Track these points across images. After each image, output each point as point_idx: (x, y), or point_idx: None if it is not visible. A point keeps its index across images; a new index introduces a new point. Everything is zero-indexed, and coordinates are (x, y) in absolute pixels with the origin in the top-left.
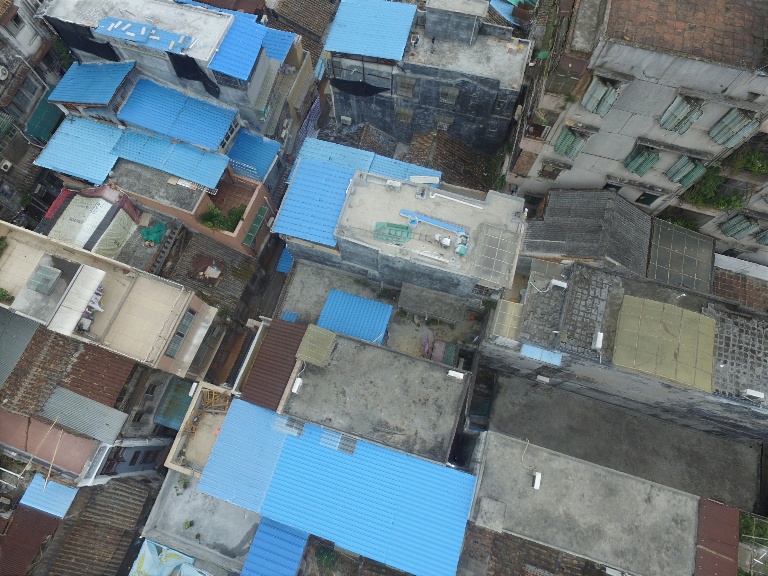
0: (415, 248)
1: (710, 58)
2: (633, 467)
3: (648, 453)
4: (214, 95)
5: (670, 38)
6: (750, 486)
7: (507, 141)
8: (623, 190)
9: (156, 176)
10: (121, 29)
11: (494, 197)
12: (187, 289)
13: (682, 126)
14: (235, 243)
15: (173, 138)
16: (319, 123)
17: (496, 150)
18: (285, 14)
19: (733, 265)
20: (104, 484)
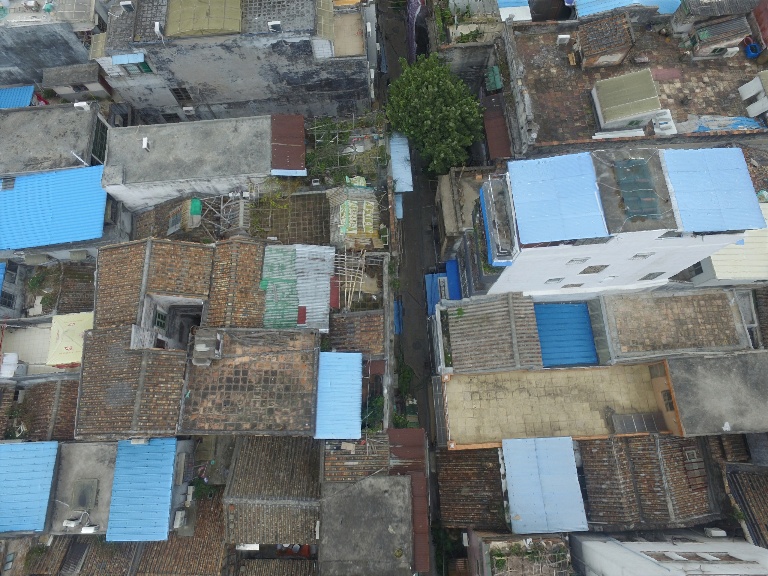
0: (12, 19)
1: None
2: None
3: None
4: None
5: None
6: None
7: None
8: None
9: None
10: None
11: None
12: None
13: None
14: None
15: None
16: None
17: None
18: None
19: None
20: None
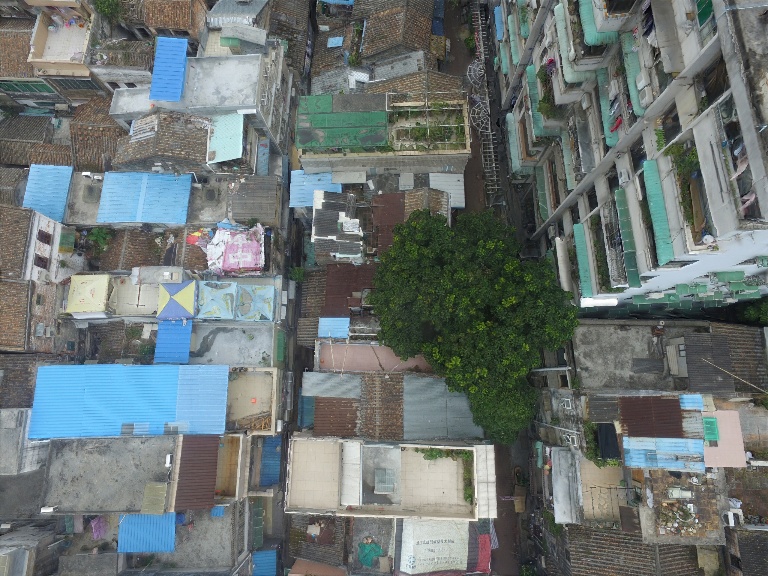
0: None
1: None
2: None
3: None
4: None
5: None
6: None
7: None
8: None
9: None
10: None
11: None
12: None
13: None
14: (298, 567)
15: None
16: None
17: None
18: None
19: None
20: None
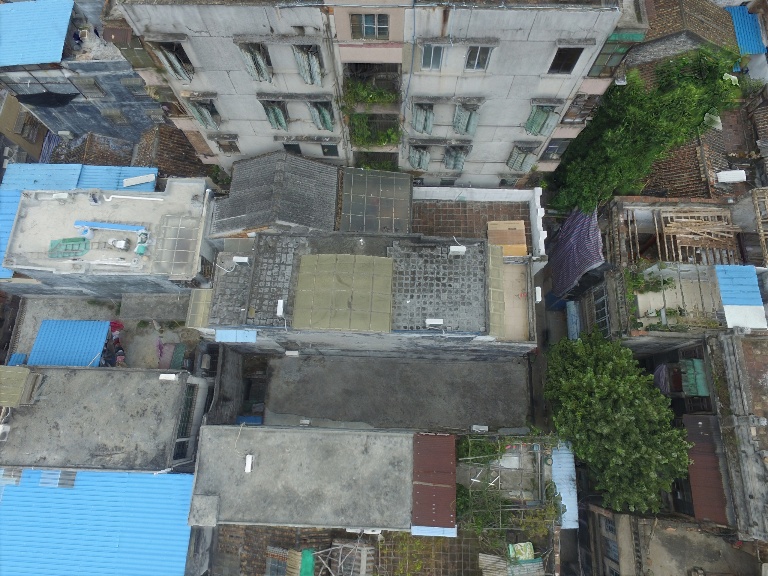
0: (94, 259)
1: None
2: (410, 413)
3: (423, 396)
4: None
5: None
6: (521, 401)
7: None
8: (302, 147)
9: None
10: None
11: (175, 185)
12: None
13: (265, 74)
14: None
15: None
16: None
17: None
18: None
19: (448, 194)
20: None
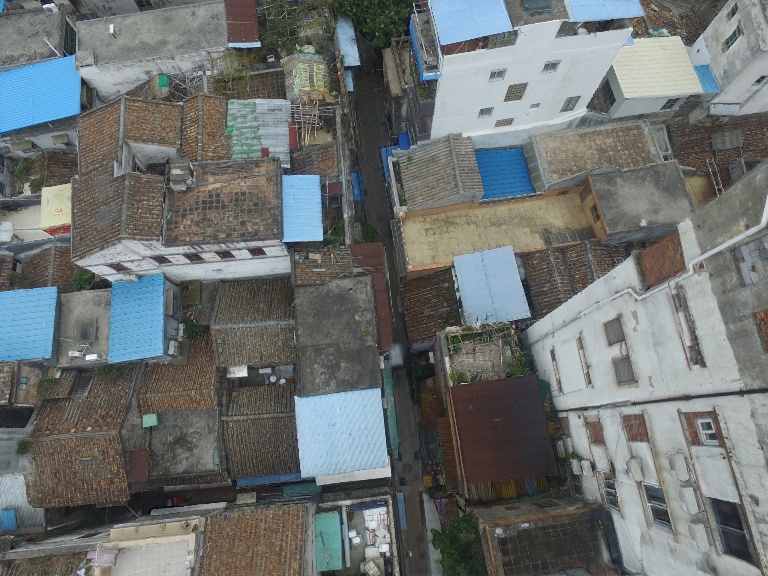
0: None
1: None
2: None
3: None
4: None
5: None
6: None
7: None
8: None
9: None
10: None
11: None
12: None
13: None
14: None
15: None
16: None
17: None
18: None
19: None
20: None
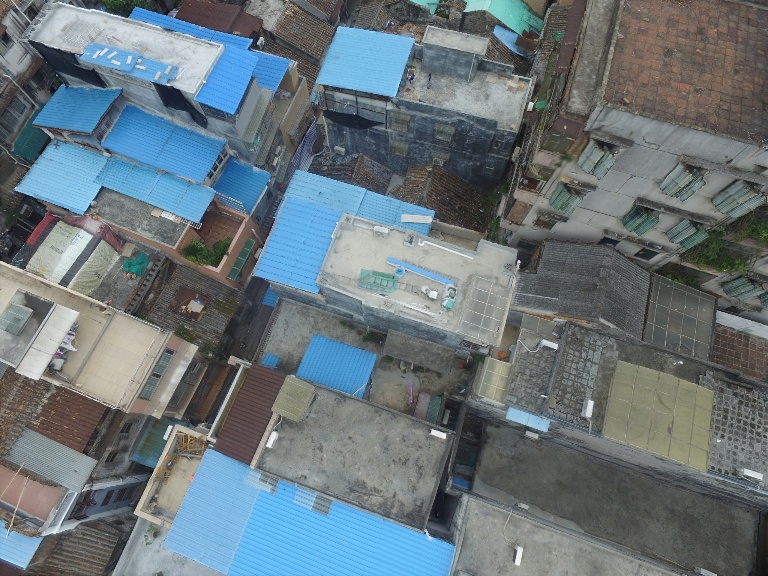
0: (401, 299)
1: (715, 127)
2: (623, 529)
3: (640, 514)
4: (202, 125)
5: (673, 101)
6: (746, 554)
7: (505, 179)
8: (621, 244)
9: (139, 207)
10: (106, 57)
11: (486, 246)
12: (165, 329)
13: (683, 193)
14: (219, 277)
15: (158, 168)
16: (315, 147)
17: (493, 187)
18: (283, 36)
19: (735, 323)
20: (72, 529)
